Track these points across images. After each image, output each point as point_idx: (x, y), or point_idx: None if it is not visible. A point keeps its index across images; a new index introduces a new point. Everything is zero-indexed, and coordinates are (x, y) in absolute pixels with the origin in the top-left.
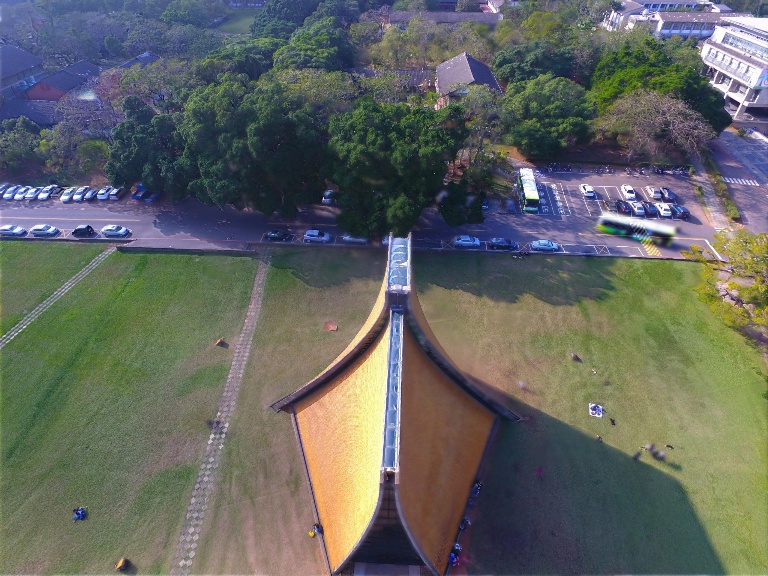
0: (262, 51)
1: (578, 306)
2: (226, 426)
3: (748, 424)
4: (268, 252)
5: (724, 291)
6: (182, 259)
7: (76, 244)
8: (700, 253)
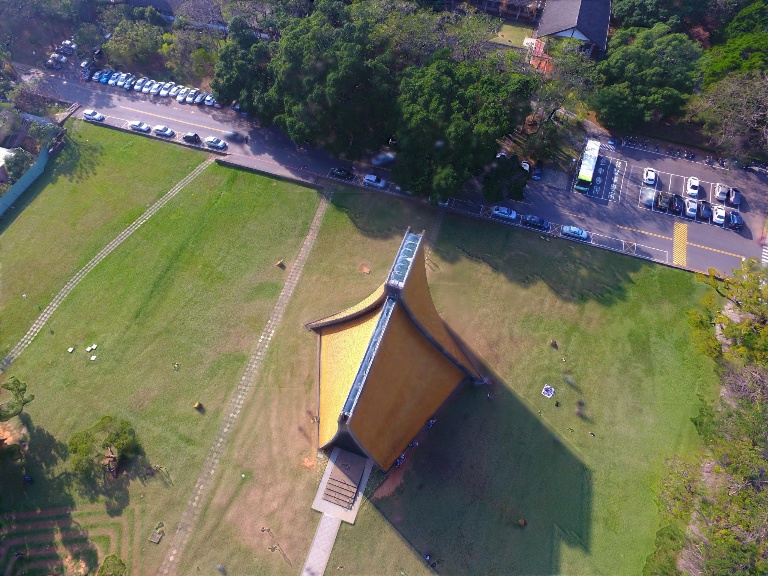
0: None
1: (579, 298)
2: (273, 332)
3: (670, 435)
4: (331, 188)
5: None
6: (263, 181)
7: (186, 149)
8: (714, 278)
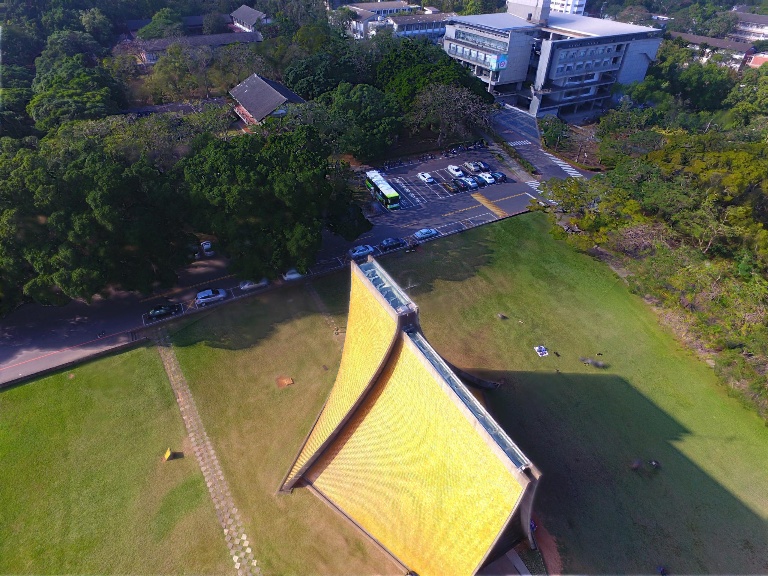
0: (5, 106)
1: (479, 275)
2: (244, 539)
3: (628, 316)
4: (161, 333)
5: (566, 227)
6: (48, 383)
7: None
8: (538, 204)
